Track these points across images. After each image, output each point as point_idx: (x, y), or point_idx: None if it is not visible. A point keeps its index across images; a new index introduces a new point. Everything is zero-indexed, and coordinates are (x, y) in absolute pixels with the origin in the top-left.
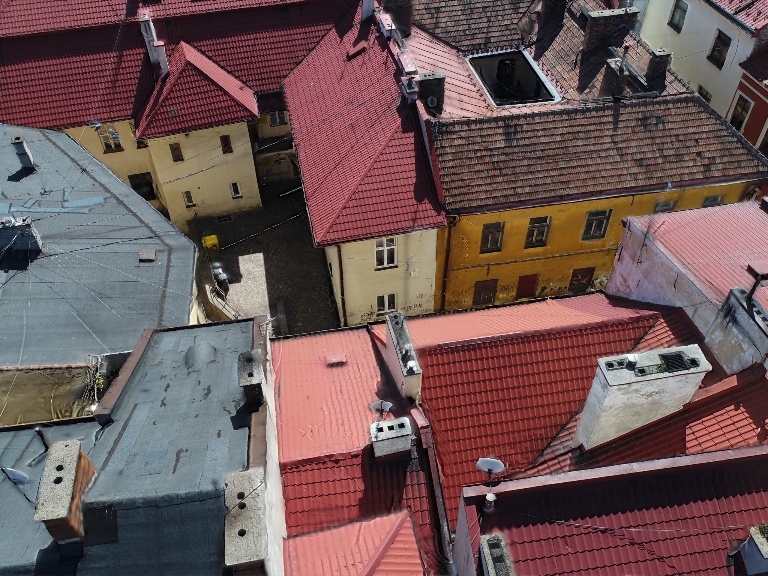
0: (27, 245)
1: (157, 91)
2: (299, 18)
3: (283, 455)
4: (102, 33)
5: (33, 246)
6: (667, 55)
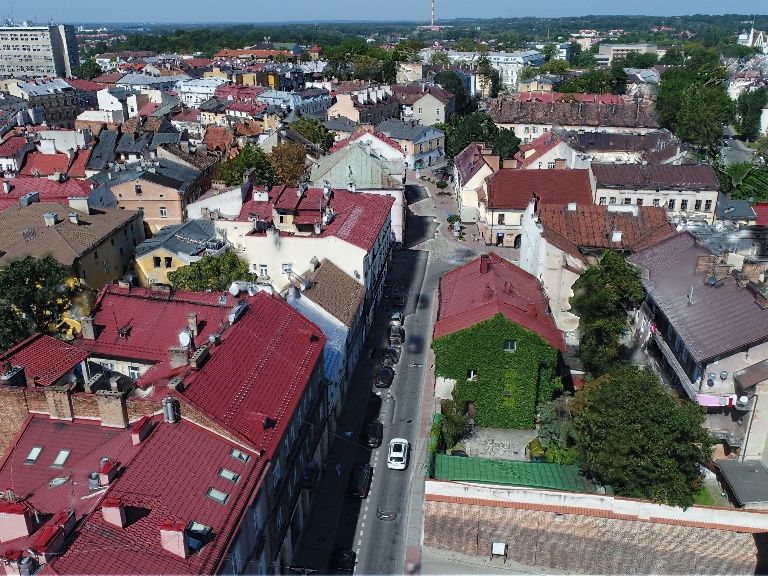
0: None
1: None
2: None
3: None
4: None
5: None
6: None
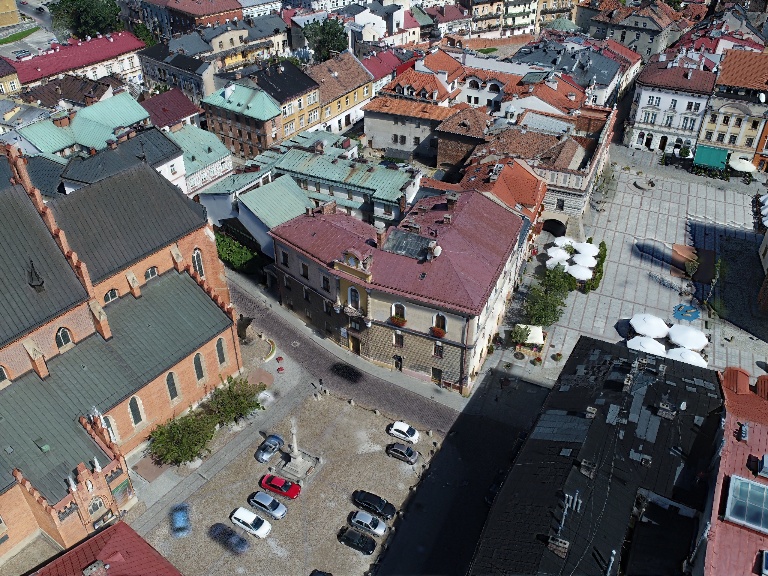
0: None
1: None
2: None
3: (739, 31)
4: None
5: None
6: None
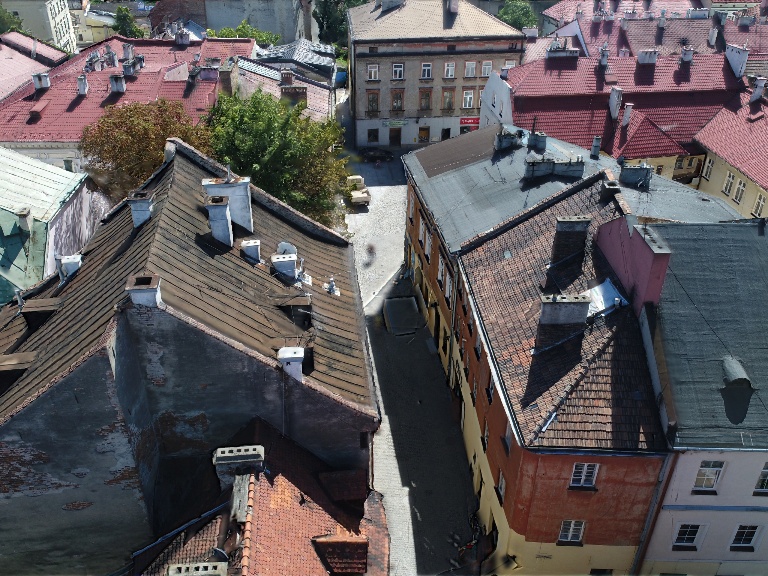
0: (645, 182)
1: (620, 134)
2: (701, 100)
3: None
4: (581, 99)
5: (647, 183)
6: None
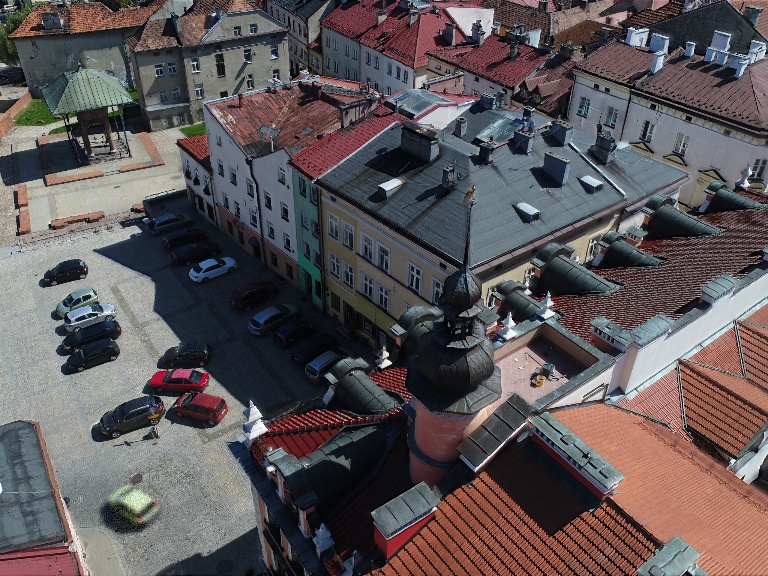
0: None
1: None
2: None
3: None
4: None
5: None
6: (561, 5)
